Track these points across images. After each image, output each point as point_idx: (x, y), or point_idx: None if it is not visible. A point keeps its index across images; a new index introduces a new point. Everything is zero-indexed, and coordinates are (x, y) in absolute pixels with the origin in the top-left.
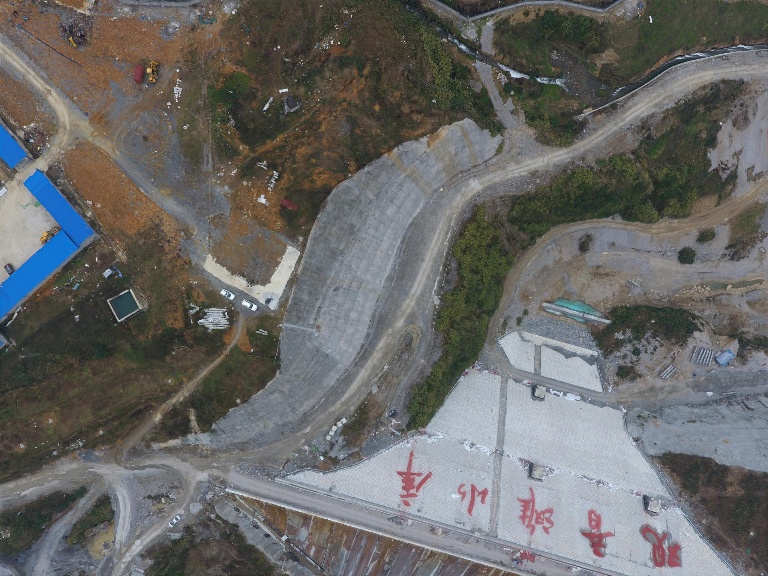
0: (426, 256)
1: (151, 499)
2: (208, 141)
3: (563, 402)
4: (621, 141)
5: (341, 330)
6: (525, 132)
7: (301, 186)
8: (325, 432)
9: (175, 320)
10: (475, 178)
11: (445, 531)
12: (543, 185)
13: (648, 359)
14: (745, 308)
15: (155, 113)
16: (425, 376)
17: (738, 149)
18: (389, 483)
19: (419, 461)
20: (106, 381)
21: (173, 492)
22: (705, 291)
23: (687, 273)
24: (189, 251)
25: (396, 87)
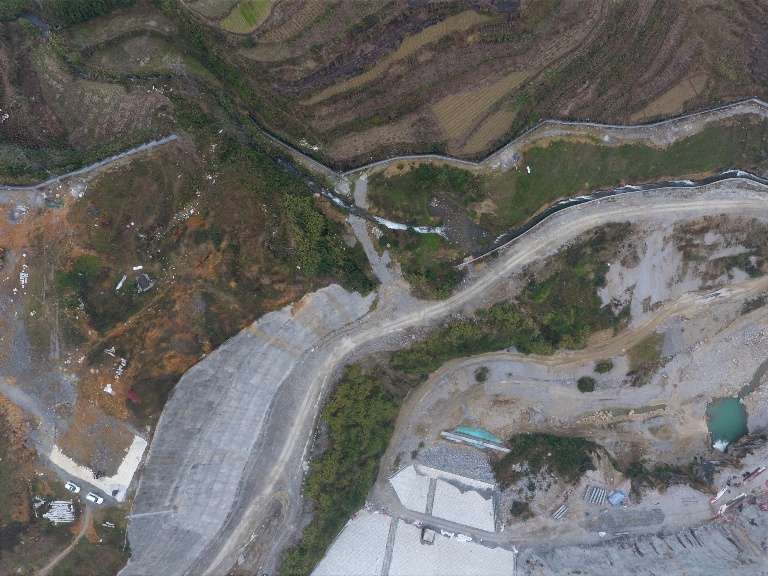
0: (295, 420)
1: None
2: (55, 328)
3: (453, 544)
4: (503, 289)
5: (202, 505)
6: (400, 287)
7: (149, 374)
8: None
9: (20, 513)
10: (348, 336)
11: None
12: (418, 341)
13: (542, 496)
14: (647, 435)
15: (1, 299)
16: (297, 540)
17: (631, 284)
18: None
19: None
20: None
21: None
22: (607, 417)
23: (587, 401)
24: (35, 442)
25: (255, 259)
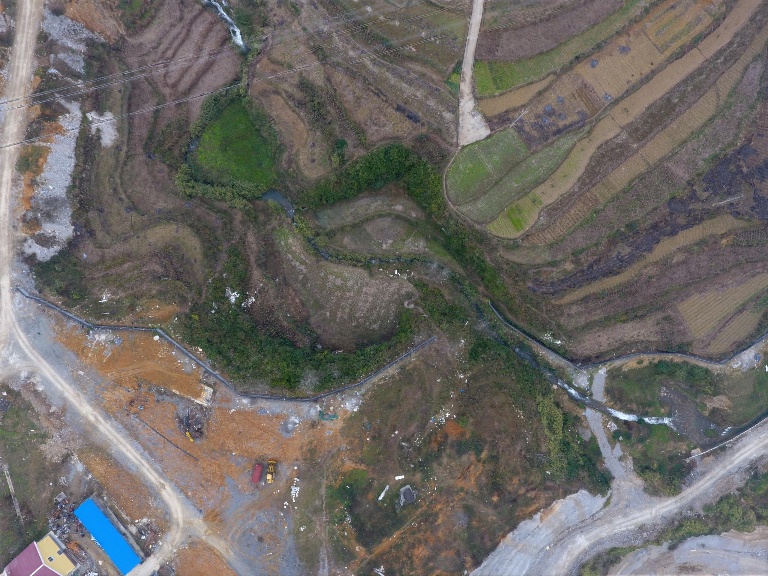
0: None
1: None
2: (324, 544)
3: None
4: (728, 482)
5: None
6: (633, 482)
7: None
8: None
9: None
10: (582, 534)
11: None
12: (650, 539)
13: None
14: None
15: (271, 513)
16: None
17: None
18: None
19: None
20: None
21: None
22: None
23: None
24: None
25: (513, 470)
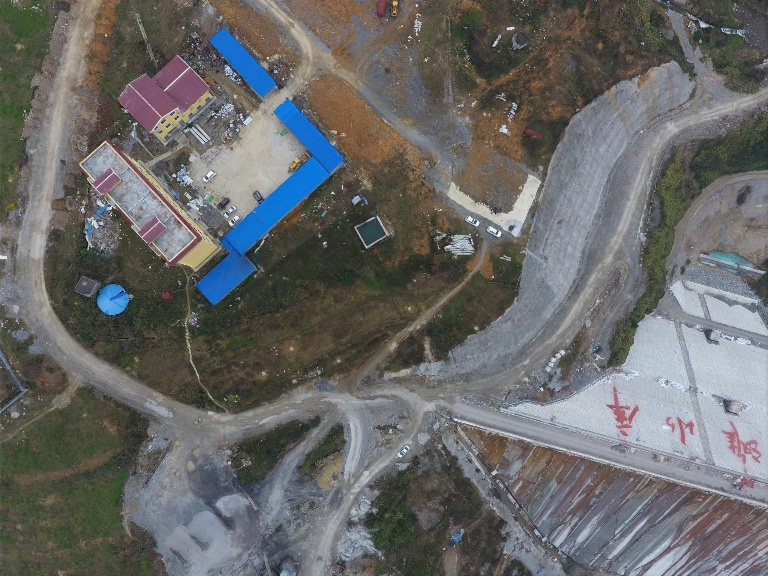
0: (631, 195)
1: (380, 430)
2: (448, 73)
3: (736, 346)
4: None
5: (561, 263)
6: (715, 78)
7: (540, 117)
8: (543, 364)
9: (421, 246)
10: (671, 121)
11: (667, 458)
12: (734, 129)
13: None
14: None
15: (396, 46)
16: (628, 312)
17: None
18: (603, 415)
19: (623, 396)
20: (348, 308)
21: (402, 422)
22: None
23: None
24: (433, 179)
25: (614, 28)
